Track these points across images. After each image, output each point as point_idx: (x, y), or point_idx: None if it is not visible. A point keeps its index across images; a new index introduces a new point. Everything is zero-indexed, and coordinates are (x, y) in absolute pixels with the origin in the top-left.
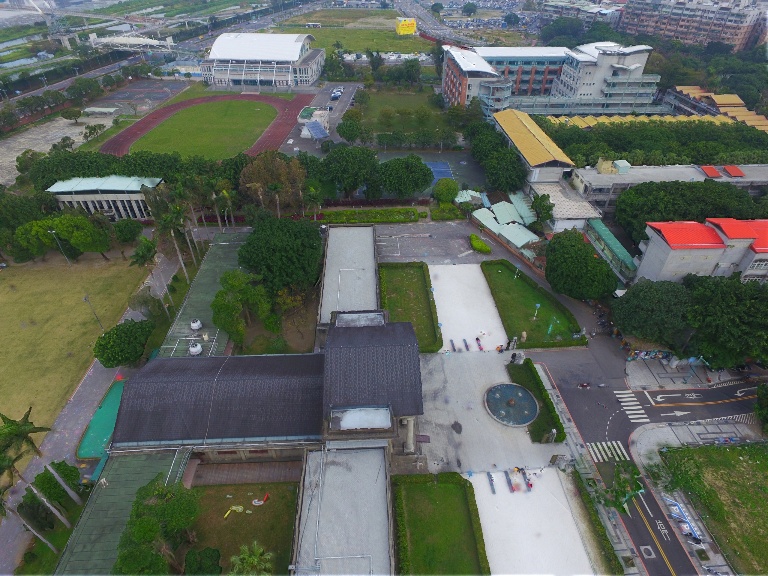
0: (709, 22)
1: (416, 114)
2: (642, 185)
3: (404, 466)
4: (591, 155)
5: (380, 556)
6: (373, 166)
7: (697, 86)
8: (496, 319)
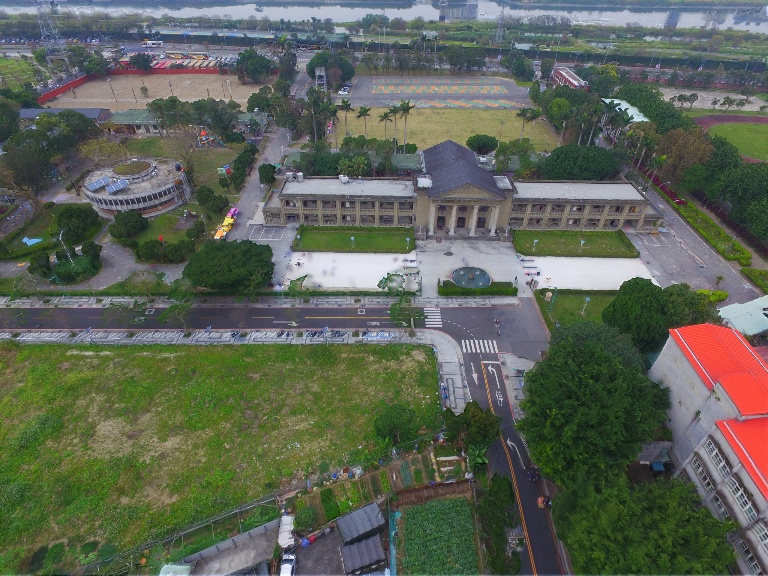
0: None
1: None
2: None
3: None
4: None
5: None
6: (767, 193)
7: None
8: None
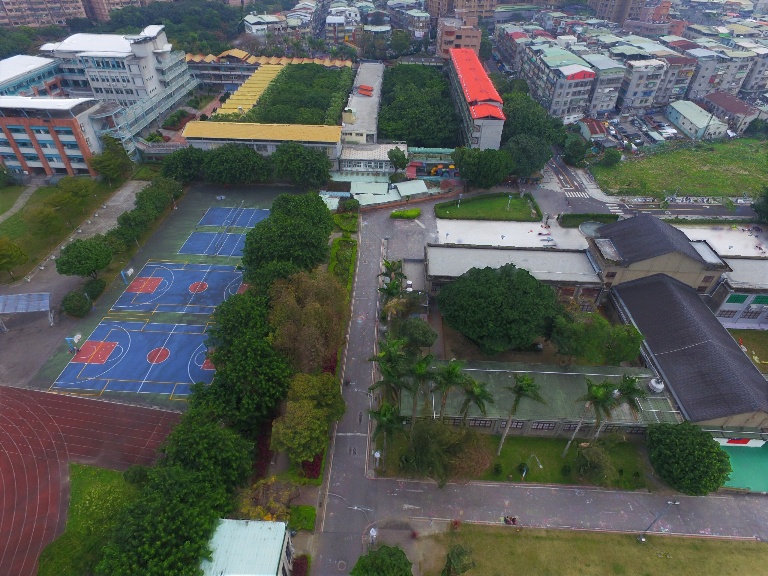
0: (40, 0)
1: (71, 194)
2: (385, 114)
3: None
4: (325, 117)
5: None
6: None
7: (188, 53)
8: (512, 224)
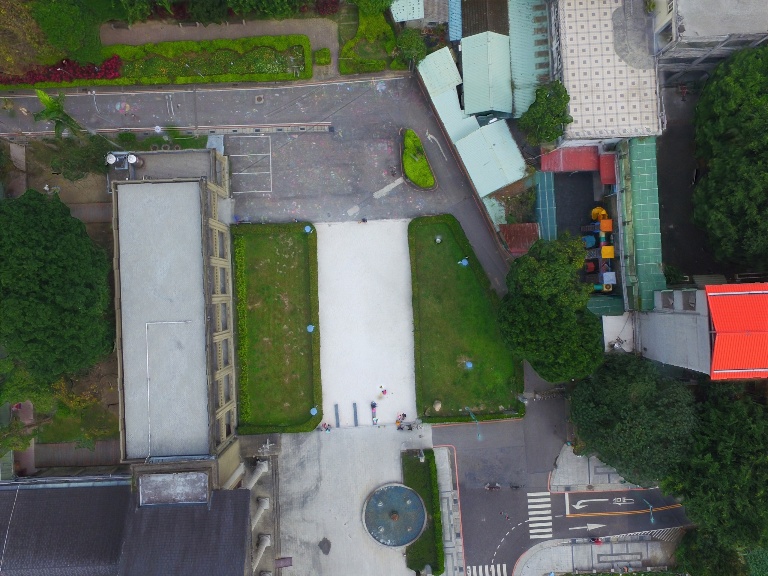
0: None
1: None
2: None
3: None
4: None
5: None
6: None
7: None
8: (408, 360)
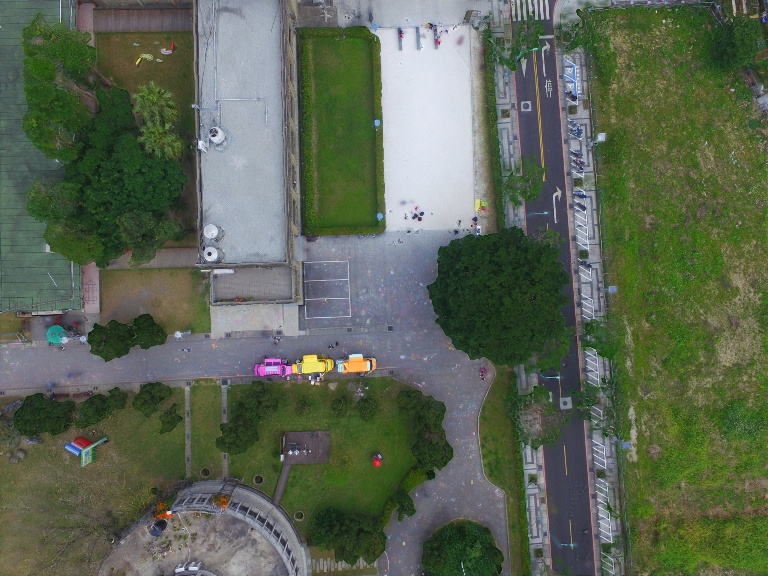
0: None
1: None
2: None
3: (312, 18)
4: None
5: (274, 99)
6: None
7: None
8: None
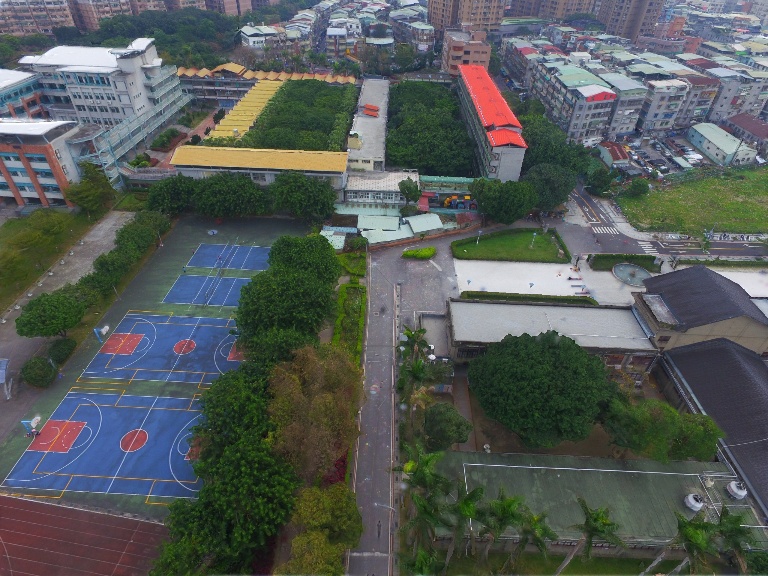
0: (25, 8)
1: (42, 231)
2: None
3: None
4: (329, 141)
5: None
6: None
7: (180, 67)
8: (537, 265)
